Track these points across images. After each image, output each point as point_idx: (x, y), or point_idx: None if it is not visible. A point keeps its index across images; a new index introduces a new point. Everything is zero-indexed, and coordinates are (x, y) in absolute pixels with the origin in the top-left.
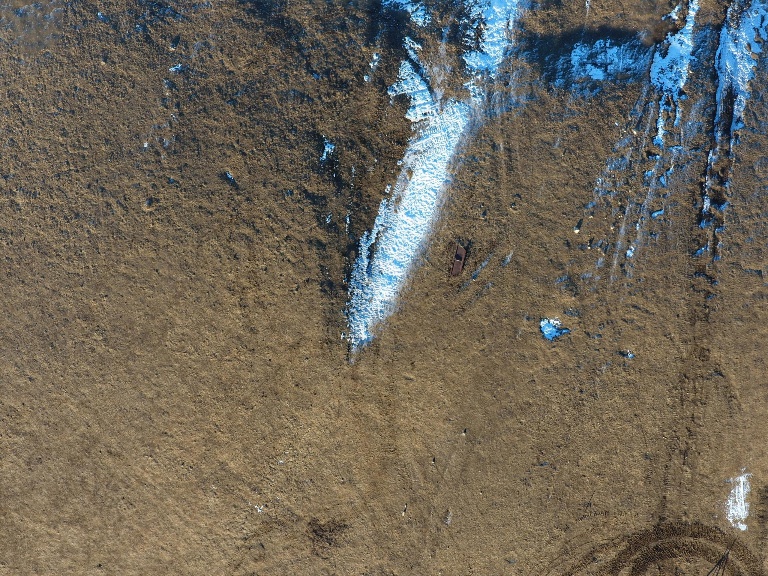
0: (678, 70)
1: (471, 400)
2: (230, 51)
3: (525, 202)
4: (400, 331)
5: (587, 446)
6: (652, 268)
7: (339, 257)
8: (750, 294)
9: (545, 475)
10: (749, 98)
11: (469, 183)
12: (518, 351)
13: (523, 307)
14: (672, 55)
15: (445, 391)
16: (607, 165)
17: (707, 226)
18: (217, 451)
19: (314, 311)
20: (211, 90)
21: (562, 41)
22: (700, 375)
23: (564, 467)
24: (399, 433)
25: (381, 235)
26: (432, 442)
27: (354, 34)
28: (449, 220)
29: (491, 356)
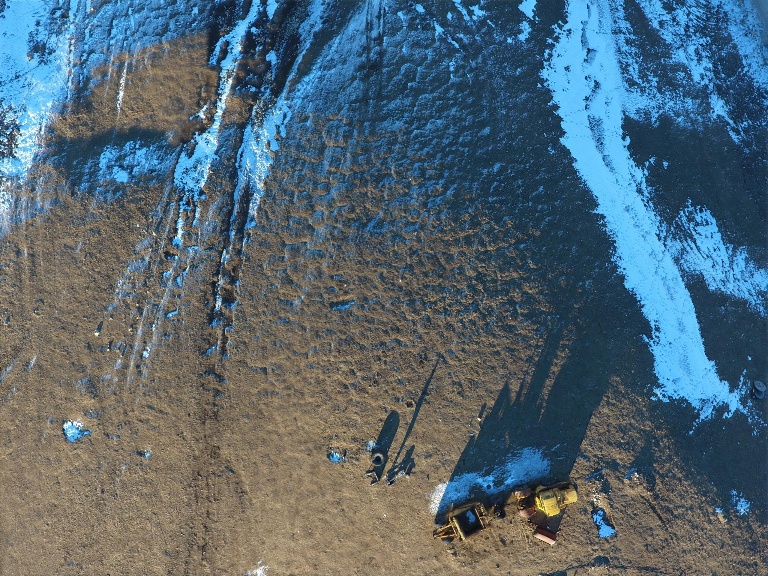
0: (201, 170)
1: (2, 503)
2: None
3: (48, 307)
4: None
5: (110, 545)
6: (165, 368)
7: None
8: (255, 391)
9: (72, 575)
10: (262, 196)
11: None
12: (43, 454)
13: (47, 410)
14: (198, 154)
15: None
16: (128, 267)
17: (217, 325)
18: None
19: None
20: None
21: (92, 144)
22: (212, 472)
23: (89, 567)
24: None
25: None
26: None
27: None
28: None
29: (18, 460)
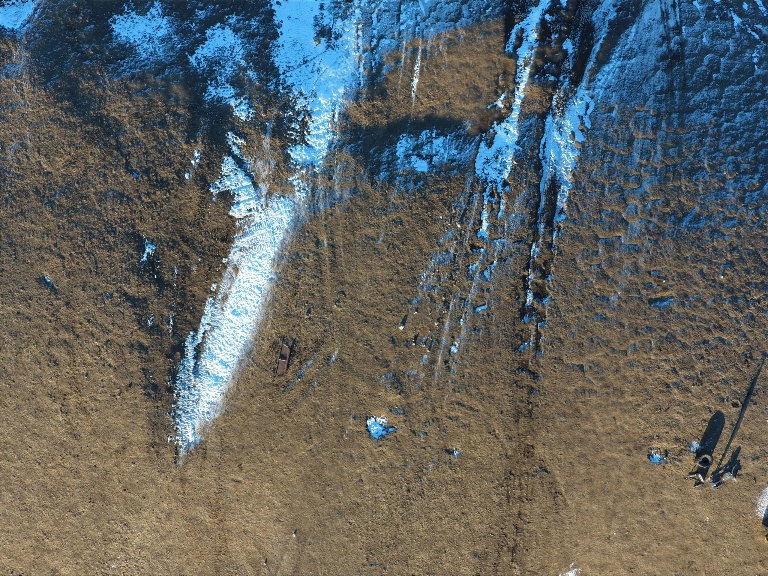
0: (503, 160)
1: (300, 501)
2: (48, 152)
3: (349, 299)
4: (226, 433)
5: (415, 545)
6: (476, 364)
7: (163, 359)
8: (572, 389)
9: (375, 575)
10: (571, 189)
11: (293, 281)
12: (345, 450)
13: (349, 406)
14: (498, 144)
15: (274, 492)
16: (431, 259)
17: (530, 320)
18: (46, 559)
19: (138, 415)
20: (28, 192)
21: (388, 132)
22: (525, 471)
23: (393, 567)
24: (230, 535)
25: (208, 334)
26: (263, 543)
27: (175, 131)
28: (273, 319)
29: (318, 456)
